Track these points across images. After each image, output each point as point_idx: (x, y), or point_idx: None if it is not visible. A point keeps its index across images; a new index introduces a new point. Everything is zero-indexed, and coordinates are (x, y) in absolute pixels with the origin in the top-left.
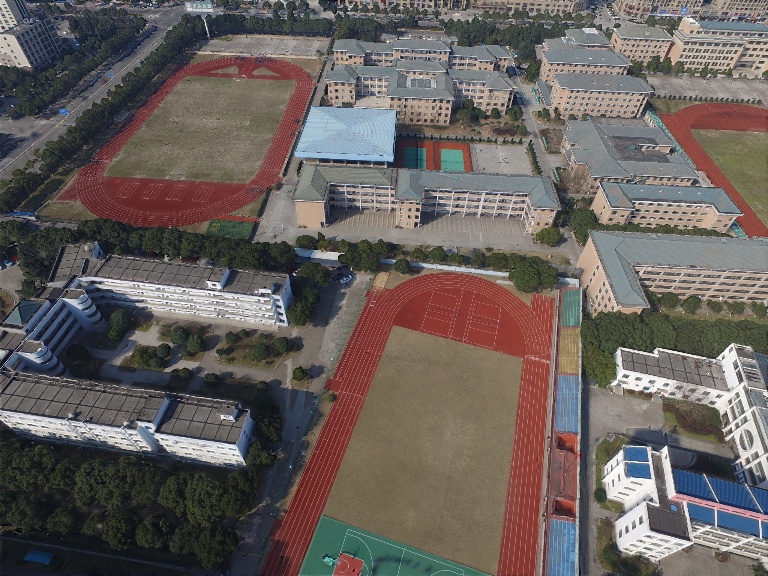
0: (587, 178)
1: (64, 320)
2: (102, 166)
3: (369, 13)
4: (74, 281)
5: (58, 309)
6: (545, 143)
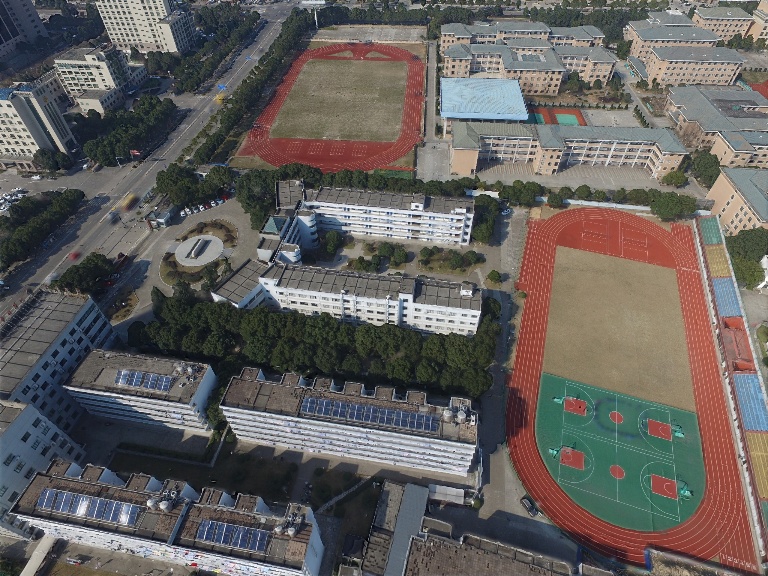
0: (698, 134)
1: (295, 235)
2: (265, 130)
3: (454, 5)
4: (301, 205)
5: (295, 225)
6: (650, 108)
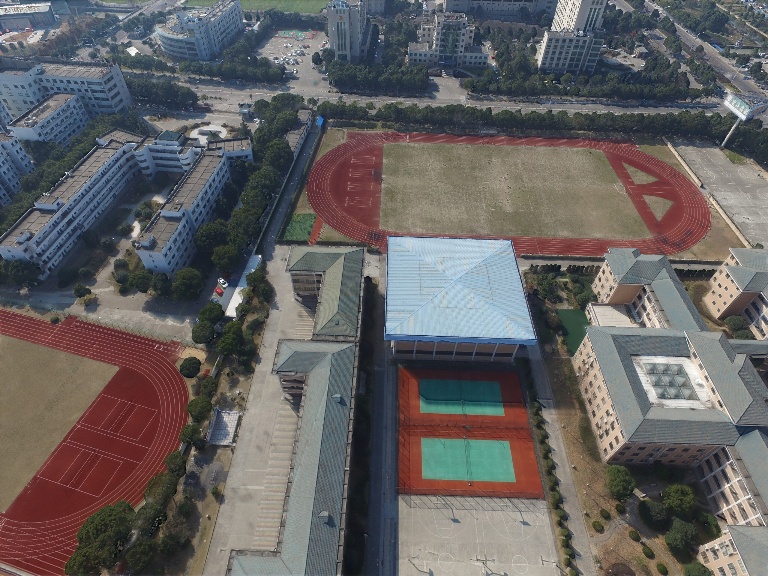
0: None
1: None
2: (399, 140)
3: None
4: None
5: None
6: None
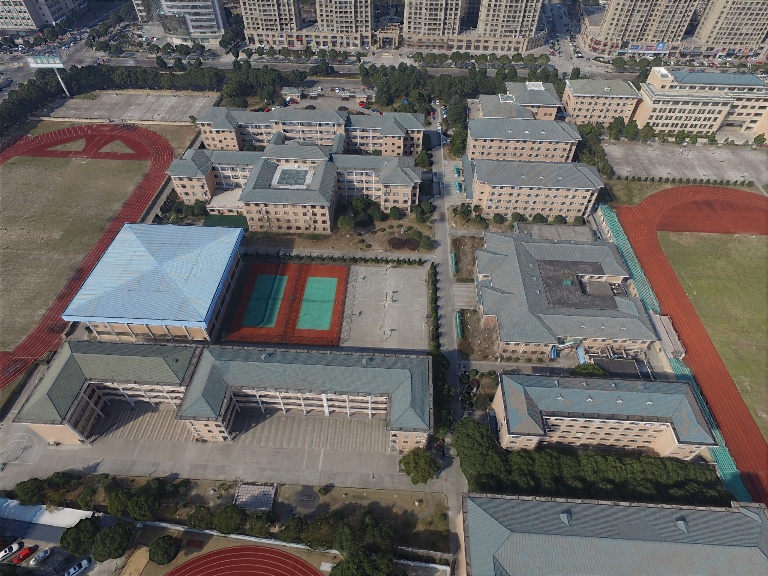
0: (498, 337)
1: None
2: None
3: None
4: None
5: None
6: (453, 265)
